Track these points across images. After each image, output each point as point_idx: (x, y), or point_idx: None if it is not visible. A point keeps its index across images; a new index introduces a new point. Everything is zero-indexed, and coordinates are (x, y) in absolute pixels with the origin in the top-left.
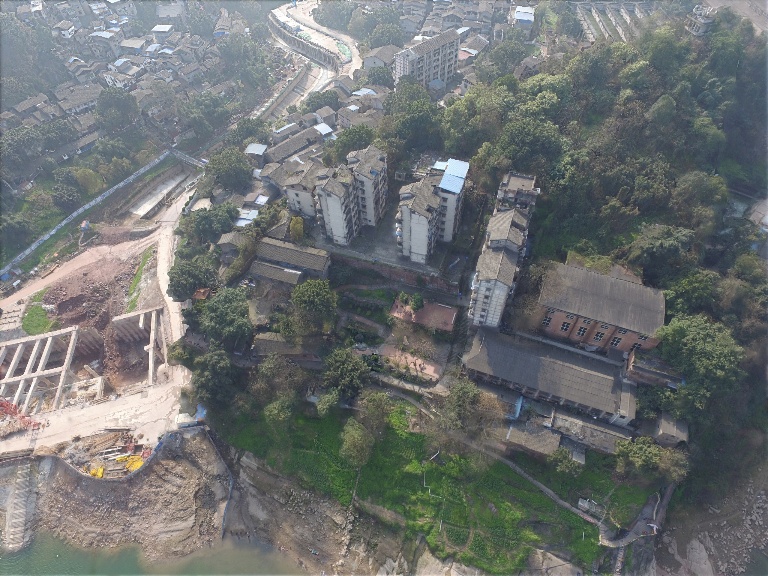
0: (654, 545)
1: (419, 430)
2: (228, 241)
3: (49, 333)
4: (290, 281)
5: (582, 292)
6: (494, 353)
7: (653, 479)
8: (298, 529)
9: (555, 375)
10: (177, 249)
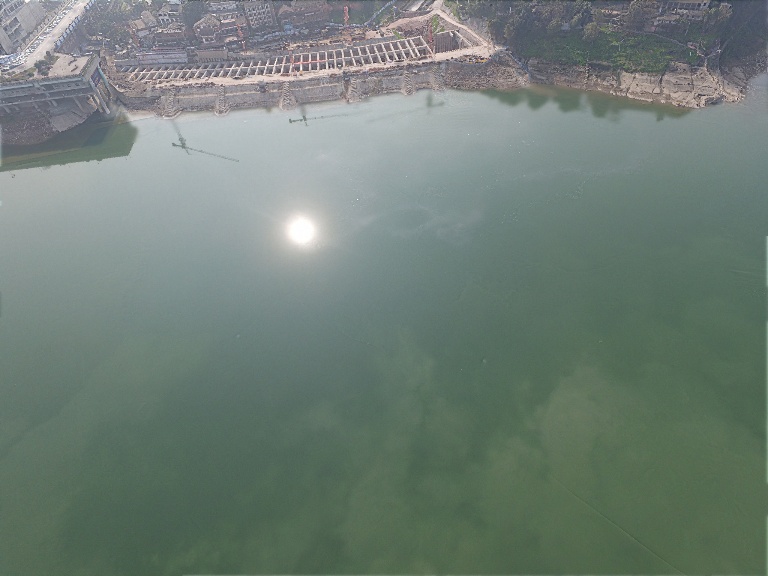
0: None
1: (615, 31)
2: None
3: (409, 38)
4: None
5: None
6: None
7: (718, 26)
8: (563, 78)
9: None
10: (453, 12)
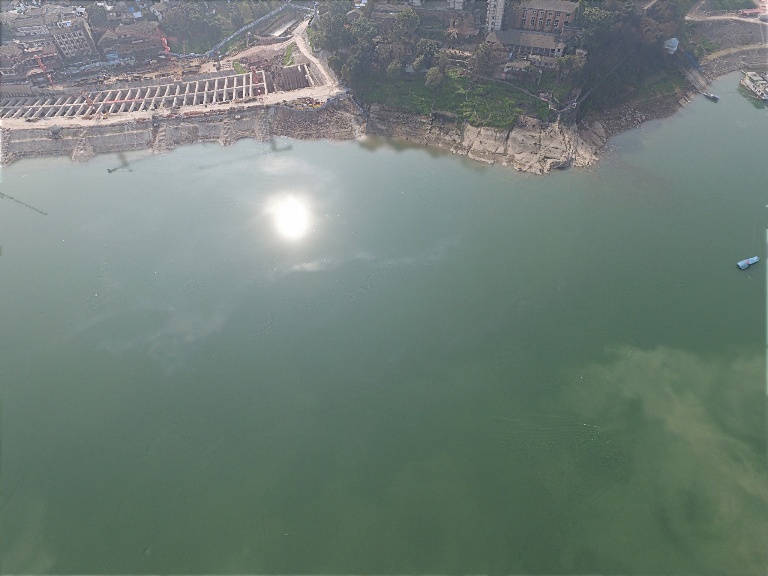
0: (577, 124)
1: (463, 76)
2: (353, 11)
3: (249, 73)
4: (393, 18)
5: (540, 3)
6: (499, 34)
7: (573, 76)
8: (404, 129)
9: (528, 38)
10: (310, 41)
